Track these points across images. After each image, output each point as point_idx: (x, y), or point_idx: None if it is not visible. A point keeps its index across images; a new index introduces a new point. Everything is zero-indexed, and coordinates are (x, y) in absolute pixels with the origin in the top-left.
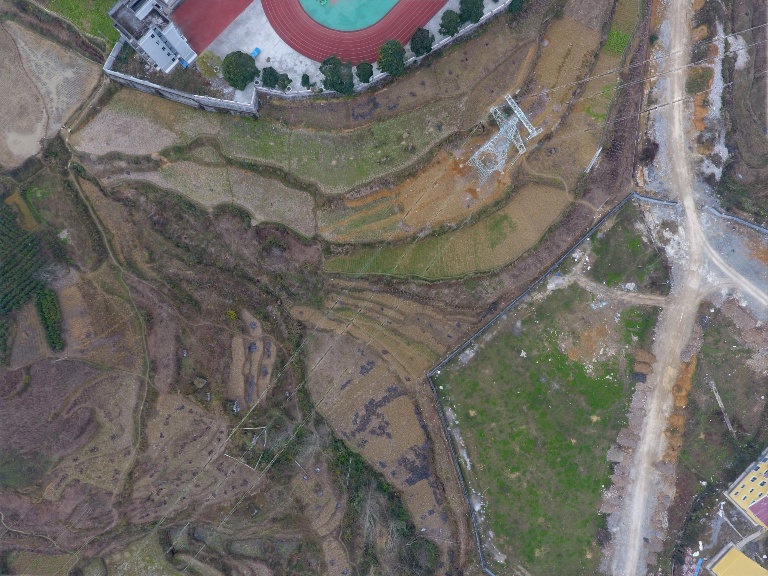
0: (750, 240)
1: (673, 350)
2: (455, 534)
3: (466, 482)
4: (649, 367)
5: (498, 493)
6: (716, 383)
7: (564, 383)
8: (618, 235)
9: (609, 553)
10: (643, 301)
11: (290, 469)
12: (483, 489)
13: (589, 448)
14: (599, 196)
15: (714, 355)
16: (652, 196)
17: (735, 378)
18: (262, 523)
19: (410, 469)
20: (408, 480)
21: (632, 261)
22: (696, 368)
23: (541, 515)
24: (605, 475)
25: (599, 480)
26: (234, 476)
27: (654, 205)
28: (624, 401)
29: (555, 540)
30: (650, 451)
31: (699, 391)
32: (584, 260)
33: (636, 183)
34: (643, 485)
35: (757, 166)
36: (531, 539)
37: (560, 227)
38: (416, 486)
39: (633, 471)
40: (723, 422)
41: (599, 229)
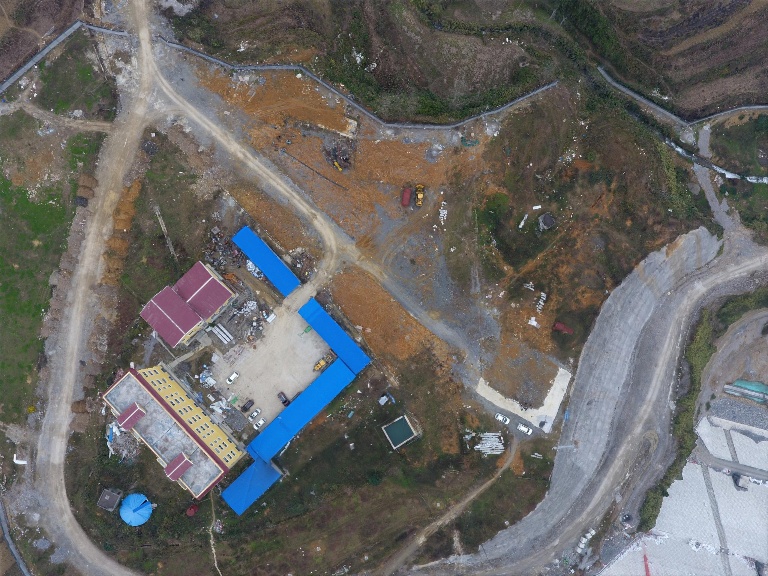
0: (199, 69)
1: (116, 175)
2: None
3: None
4: (89, 191)
5: None
6: (161, 208)
7: (6, 208)
8: (68, 64)
9: (42, 376)
10: (89, 128)
11: None
12: None
13: (31, 273)
14: (45, 24)
15: (160, 181)
16: (107, 27)
17: (179, 203)
18: None
19: None
20: None
21: (81, 89)
22: (140, 193)
23: None
24: (46, 299)
25: (40, 304)
26: None
27: (109, 36)
28: (66, 225)
29: None
30: (89, 274)
31: (143, 216)
32: (31, 87)
33: (91, 15)
34: (80, 308)
35: (236, 7)
36: None
37: (3, 53)
38: None
39: (70, 294)
40: (165, 246)
41: (47, 57)
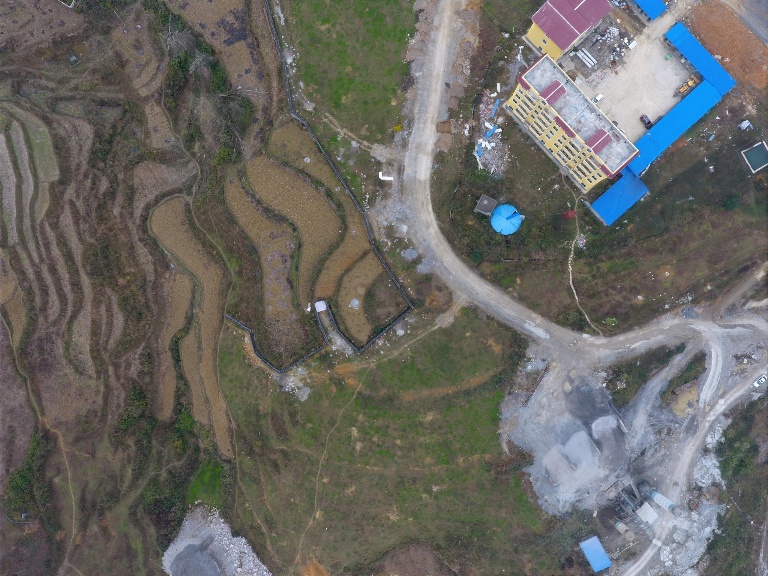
0: None
1: None
2: (268, 87)
3: (279, 36)
4: None
5: (309, 45)
6: None
7: None
8: None
9: (411, 95)
10: None
11: (109, 19)
12: (295, 41)
13: None
14: None
15: None
16: None
17: None
18: (83, 75)
19: (229, 31)
20: (226, 41)
21: None
22: None
23: (349, 64)
24: (411, 25)
25: (405, 30)
26: (51, 15)
27: None
28: None
29: (362, 88)
30: (454, 0)
31: None
32: None
33: None
34: (446, 32)
35: None
36: (338, 86)
37: None
38: (234, 47)
39: (437, 18)
40: None
41: None
